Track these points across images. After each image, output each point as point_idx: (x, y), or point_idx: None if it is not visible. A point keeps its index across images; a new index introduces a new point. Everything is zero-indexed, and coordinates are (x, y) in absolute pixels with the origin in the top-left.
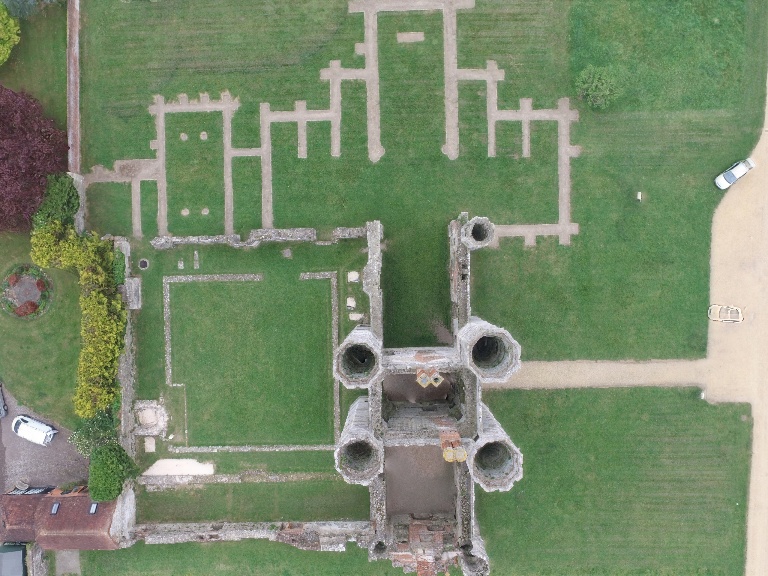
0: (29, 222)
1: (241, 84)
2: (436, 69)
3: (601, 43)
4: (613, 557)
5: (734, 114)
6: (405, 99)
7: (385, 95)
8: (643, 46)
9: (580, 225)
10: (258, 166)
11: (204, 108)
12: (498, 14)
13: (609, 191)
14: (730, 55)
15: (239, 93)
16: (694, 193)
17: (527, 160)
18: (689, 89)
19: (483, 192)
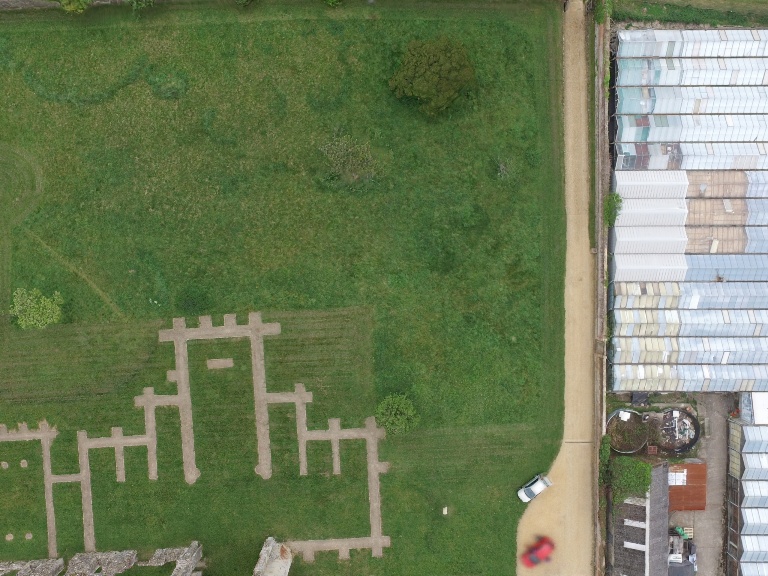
0: None
1: (58, 413)
2: (246, 394)
3: (404, 364)
4: None
5: (534, 427)
6: (217, 423)
7: (198, 420)
8: (445, 365)
9: (391, 538)
10: (78, 491)
11: (23, 437)
12: (304, 339)
13: (417, 505)
14: (528, 372)
15: (56, 422)
16: (499, 504)
17: (338, 477)
18: (490, 405)
19: (297, 509)
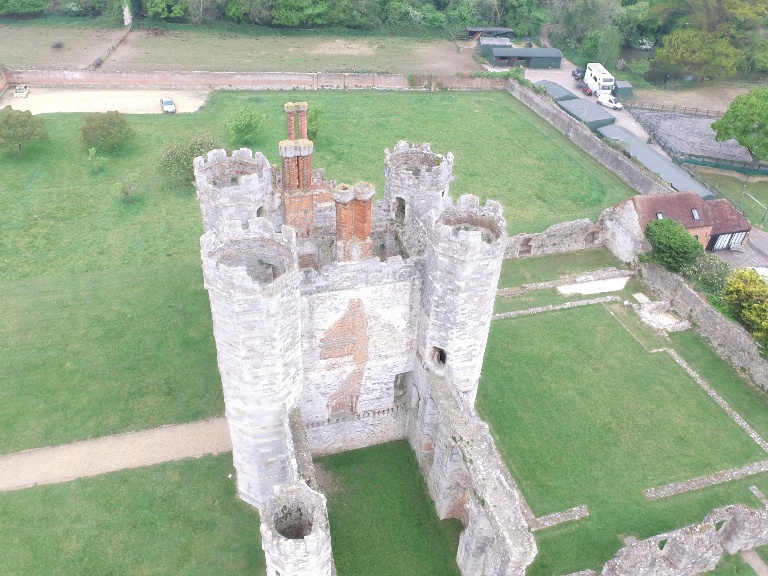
0: None
1: None
2: None
3: None
4: (59, 283)
5: None
6: None
7: None
8: None
9: None
10: None
11: None
12: None
13: None
14: None
15: None
16: None
17: None
18: None
19: None
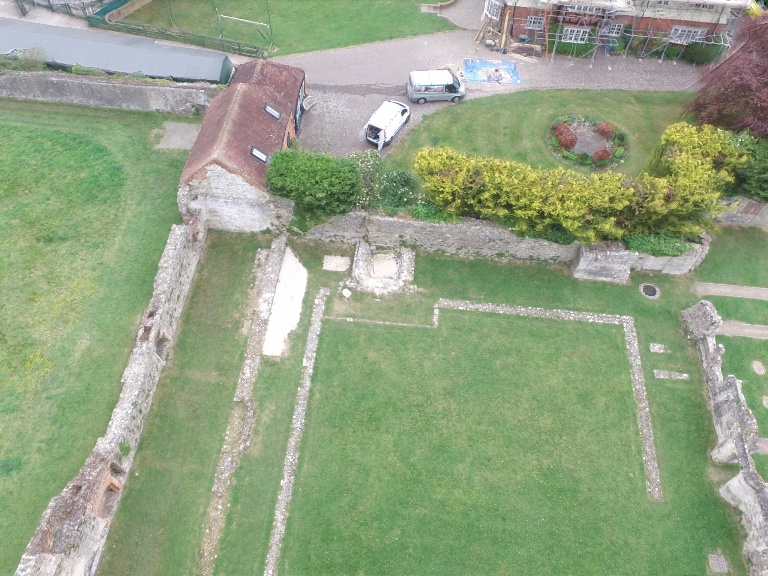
0: (735, 127)
1: None
2: None
3: None
4: None
5: None
6: None
7: None
8: None
9: None
10: None
11: None
12: None
13: None
14: None
15: None
16: None
17: None
18: None
19: None
